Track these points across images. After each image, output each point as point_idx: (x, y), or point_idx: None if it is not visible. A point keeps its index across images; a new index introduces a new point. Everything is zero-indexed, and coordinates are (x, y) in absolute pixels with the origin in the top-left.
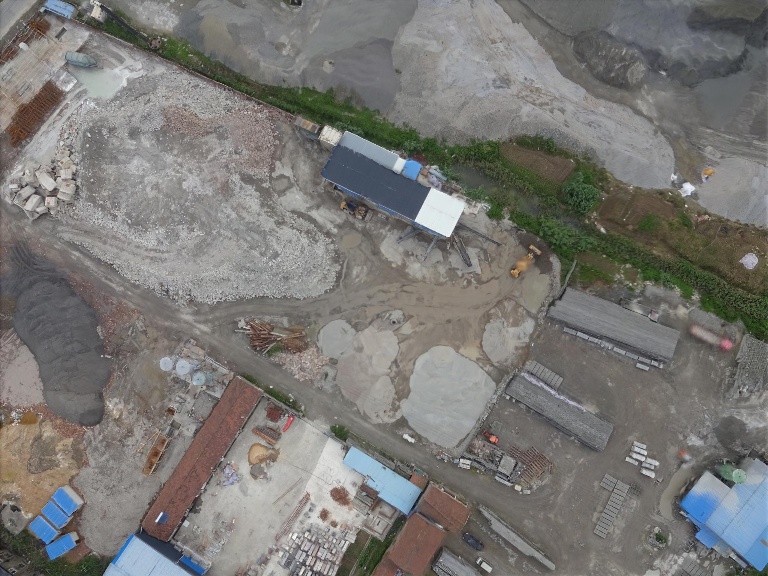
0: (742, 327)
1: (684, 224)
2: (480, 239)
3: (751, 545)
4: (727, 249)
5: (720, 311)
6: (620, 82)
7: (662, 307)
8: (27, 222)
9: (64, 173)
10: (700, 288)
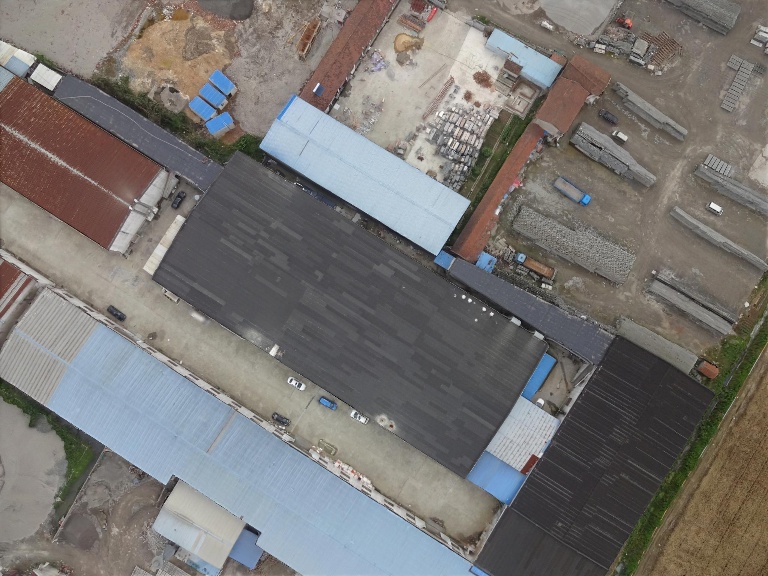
0: None
1: None
2: None
3: None
4: None
5: None
6: None
7: None
8: None
9: None
10: None
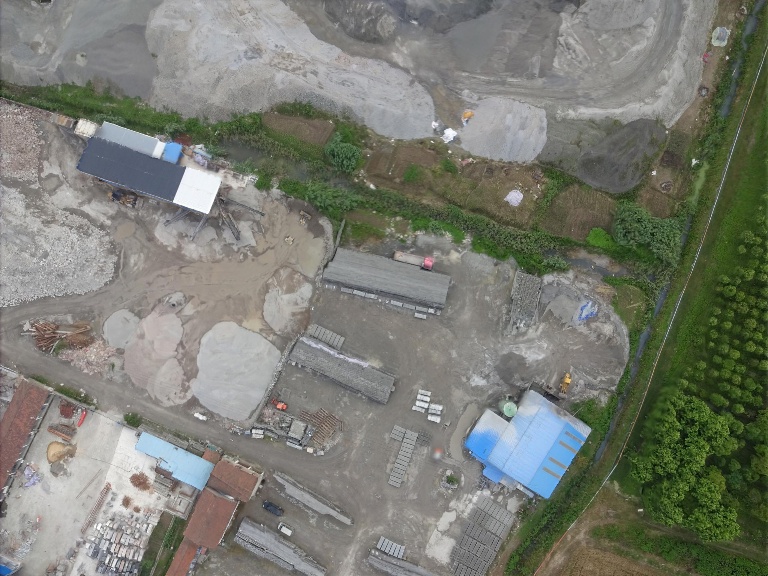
0: (514, 264)
1: (446, 170)
2: (251, 212)
3: (533, 475)
4: (492, 189)
5: (490, 251)
6: (373, 37)
7: (435, 255)
8: None
9: None
10: (472, 231)
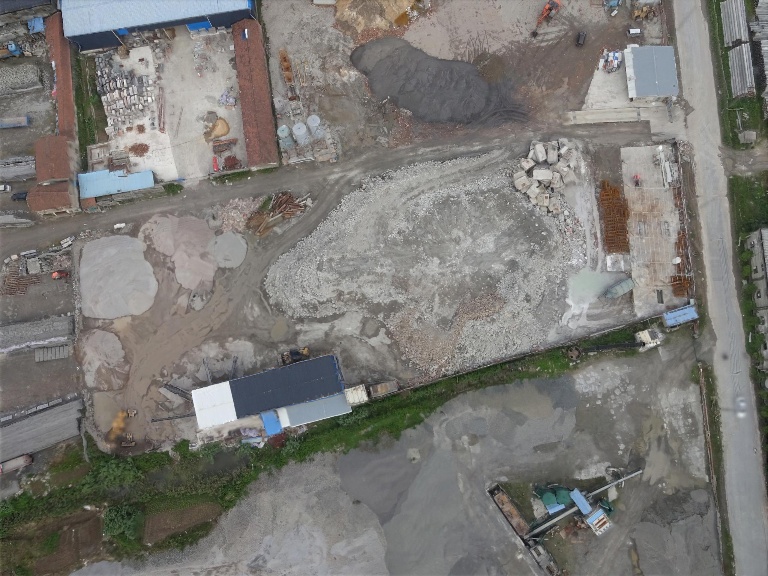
0: None
1: (20, 567)
2: None
3: None
4: None
5: None
6: None
7: None
8: (536, 138)
9: (535, 191)
10: None
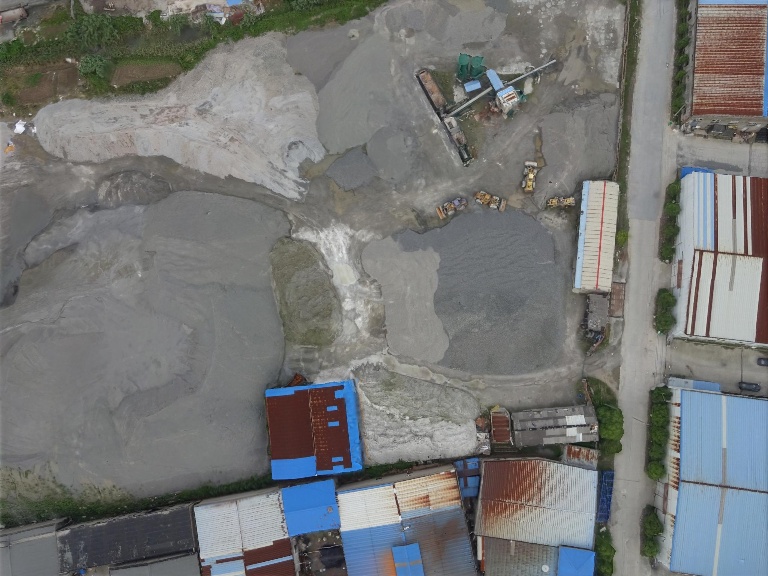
0: None
1: (7, 94)
2: None
3: None
4: None
5: None
6: (114, 176)
7: None
8: None
9: None
10: None
